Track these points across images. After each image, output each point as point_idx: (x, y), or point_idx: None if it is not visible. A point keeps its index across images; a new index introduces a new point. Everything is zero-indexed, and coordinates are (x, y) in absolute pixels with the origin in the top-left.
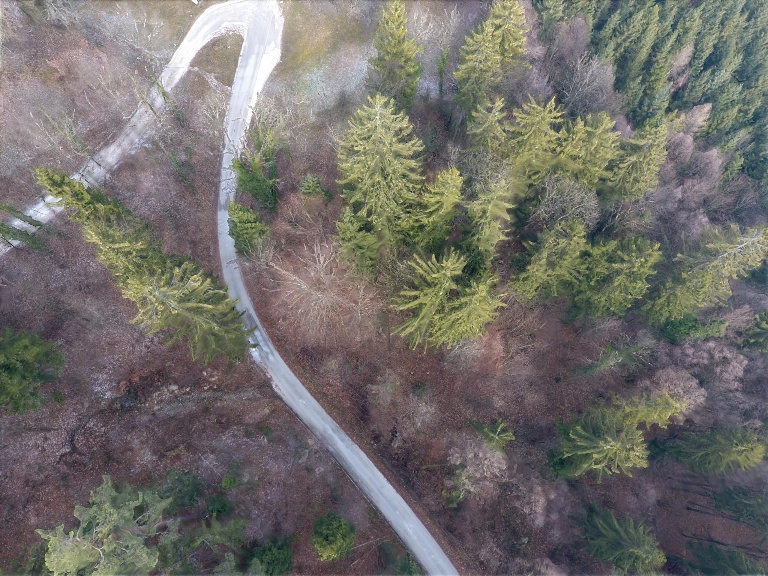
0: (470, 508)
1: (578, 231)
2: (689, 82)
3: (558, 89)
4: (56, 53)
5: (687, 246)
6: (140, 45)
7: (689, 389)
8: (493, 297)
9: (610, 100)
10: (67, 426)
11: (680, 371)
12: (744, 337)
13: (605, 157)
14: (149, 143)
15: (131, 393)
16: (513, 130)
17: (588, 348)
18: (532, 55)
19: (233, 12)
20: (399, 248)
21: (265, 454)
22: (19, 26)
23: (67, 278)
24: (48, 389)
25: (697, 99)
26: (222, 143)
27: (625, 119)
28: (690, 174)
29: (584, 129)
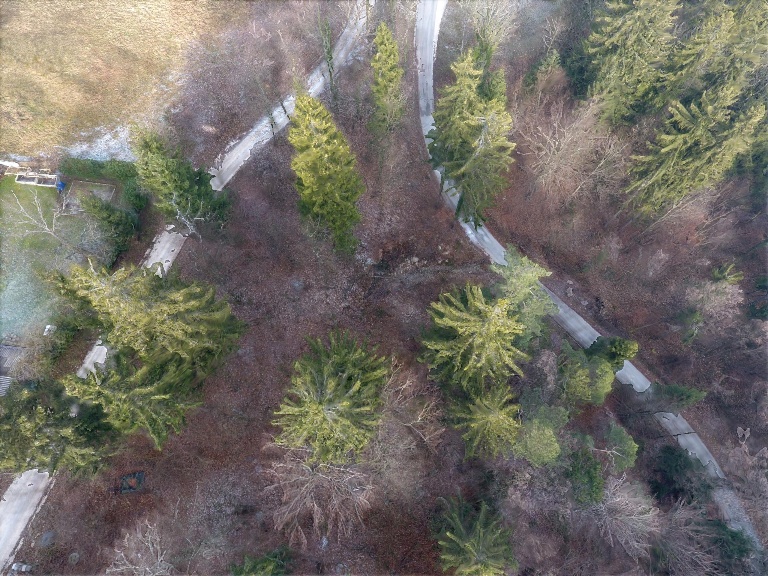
0: None
1: None
2: None
3: None
4: None
5: None
6: None
7: None
8: None
9: None
10: (341, 285)
11: None
12: None
13: None
14: (360, 56)
15: (385, 261)
16: None
17: (746, 238)
18: None
19: None
20: None
21: None
22: None
23: None
24: None
25: None
26: (415, 59)
27: None
28: None
29: None
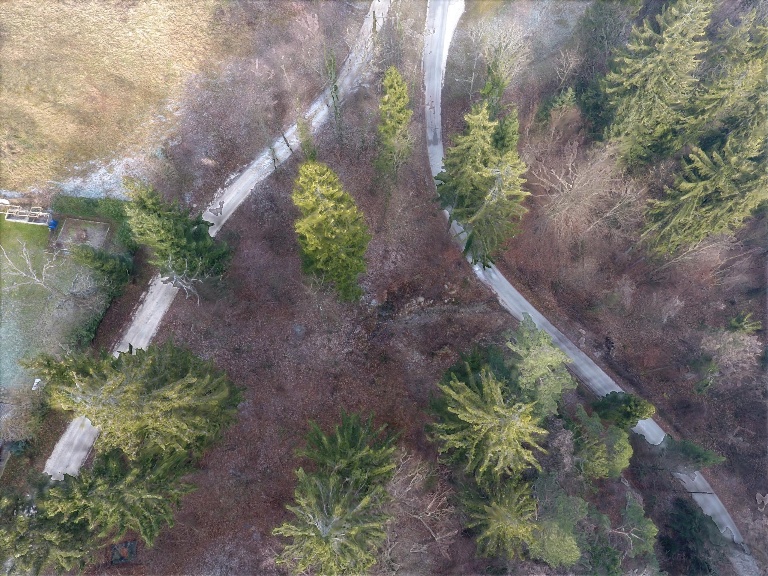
0: None
1: None
2: None
3: None
4: (280, 2)
5: None
6: None
7: None
8: None
9: None
10: (344, 329)
11: None
12: None
13: None
14: (366, 83)
15: (390, 302)
16: None
17: (759, 272)
18: None
19: None
20: None
21: None
22: None
23: None
24: (322, 297)
25: None
26: (422, 85)
27: None
28: None
29: None
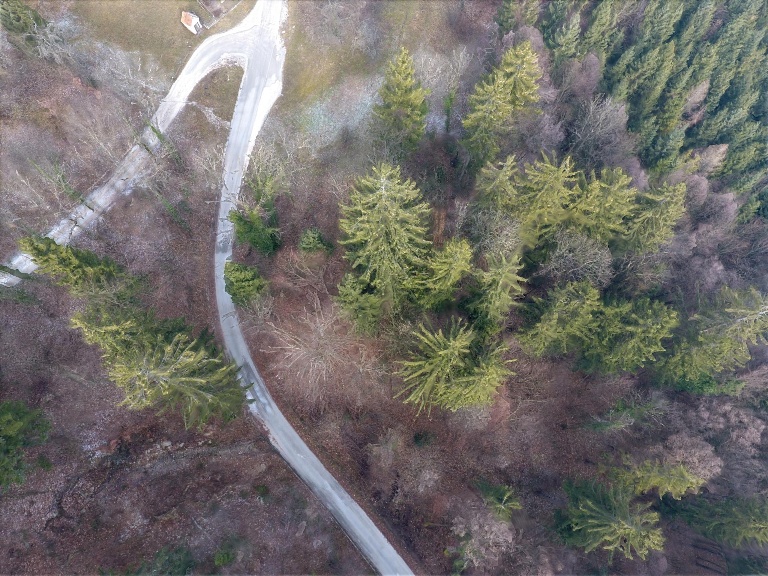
0: (473, 568)
1: (591, 295)
2: (704, 120)
3: (570, 131)
4: (48, 89)
5: (701, 294)
6: (136, 78)
7: (704, 458)
8: (502, 366)
9: (623, 143)
10: (55, 488)
11: (695, 437)
12: (761, 398)
13: (620, 213)
14: None
15: (122, 451)
16: (524, 185)
17: (596, 394)
18: (544, 99)
19: (233, 42)
20: (403, 303)
21: (261, 516)
22: (9, 64)
23: (57, 328)
24: (35, 448)
25: (712, 137)
26: (220, 181)
27: (639, 162)
28: (704, 216)
29: (599, 187)
